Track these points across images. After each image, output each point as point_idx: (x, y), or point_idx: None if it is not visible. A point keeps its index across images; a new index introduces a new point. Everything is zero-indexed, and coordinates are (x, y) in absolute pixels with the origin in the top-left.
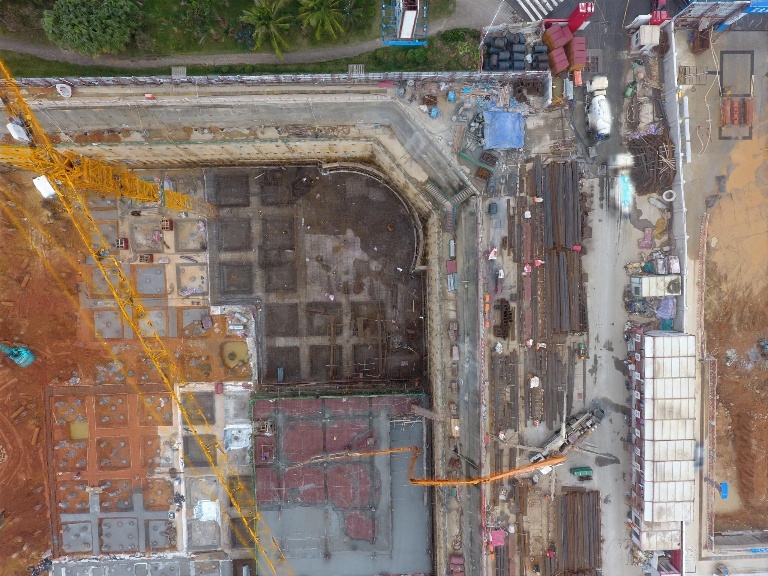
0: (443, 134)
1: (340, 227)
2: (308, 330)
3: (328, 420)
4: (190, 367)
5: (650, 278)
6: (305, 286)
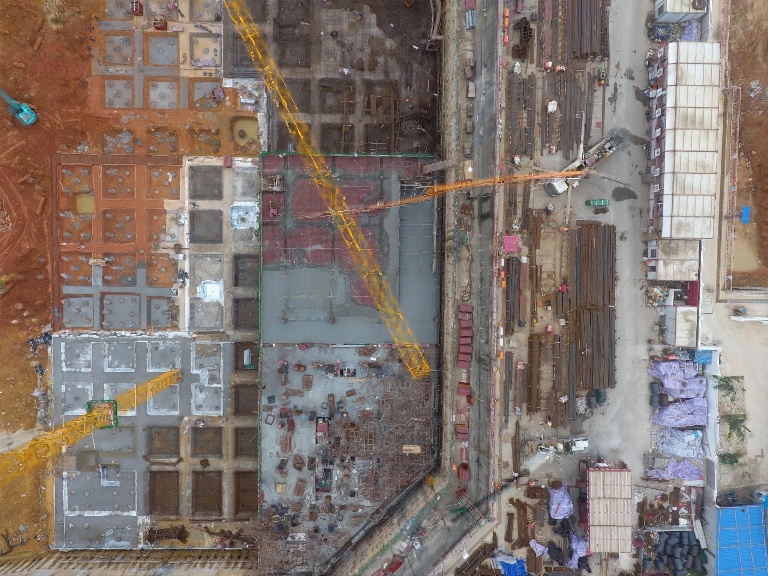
0: None
1: (357, 1)
2: (320, 106)
3: (338, 179)
4: (199, 142)
5: None
6: (319, 62)
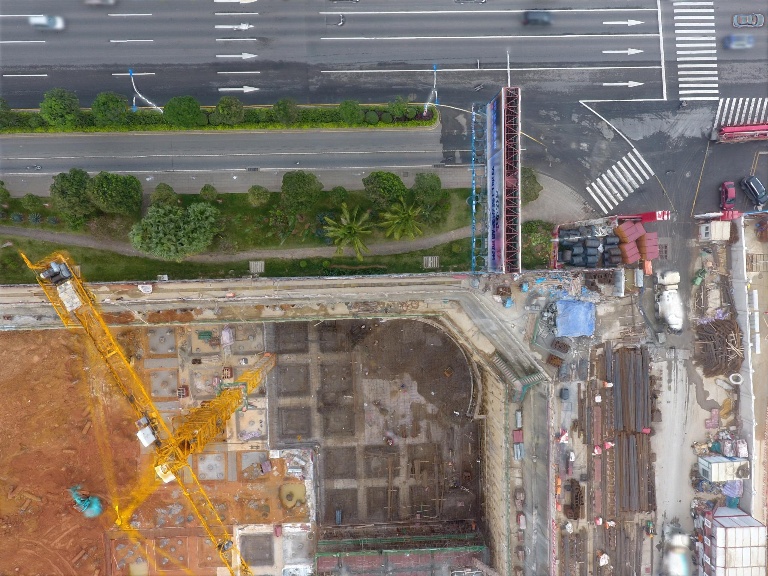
0: (516, 322)
1: (398, 372)
2: (366, 473)
3: (391, 573)
4: (249, 508)
5: (719, 464)
6: (363, 429)
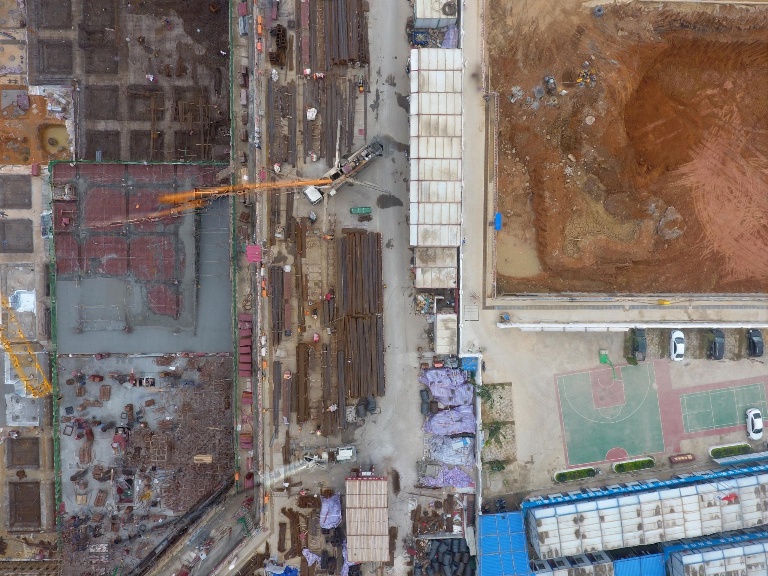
0: None
1: (162, 7)
2: (128, 113)
3: (131, 188)
4: (8, 150)
5: None
6: (126, 68)
